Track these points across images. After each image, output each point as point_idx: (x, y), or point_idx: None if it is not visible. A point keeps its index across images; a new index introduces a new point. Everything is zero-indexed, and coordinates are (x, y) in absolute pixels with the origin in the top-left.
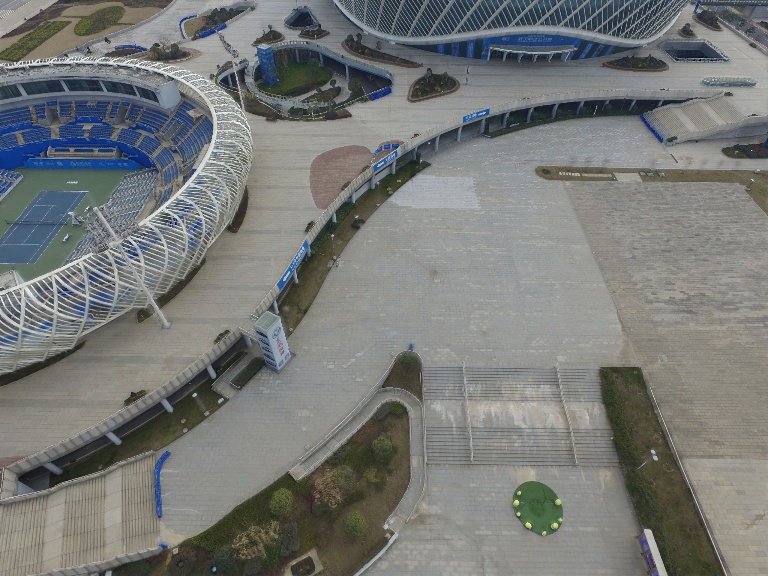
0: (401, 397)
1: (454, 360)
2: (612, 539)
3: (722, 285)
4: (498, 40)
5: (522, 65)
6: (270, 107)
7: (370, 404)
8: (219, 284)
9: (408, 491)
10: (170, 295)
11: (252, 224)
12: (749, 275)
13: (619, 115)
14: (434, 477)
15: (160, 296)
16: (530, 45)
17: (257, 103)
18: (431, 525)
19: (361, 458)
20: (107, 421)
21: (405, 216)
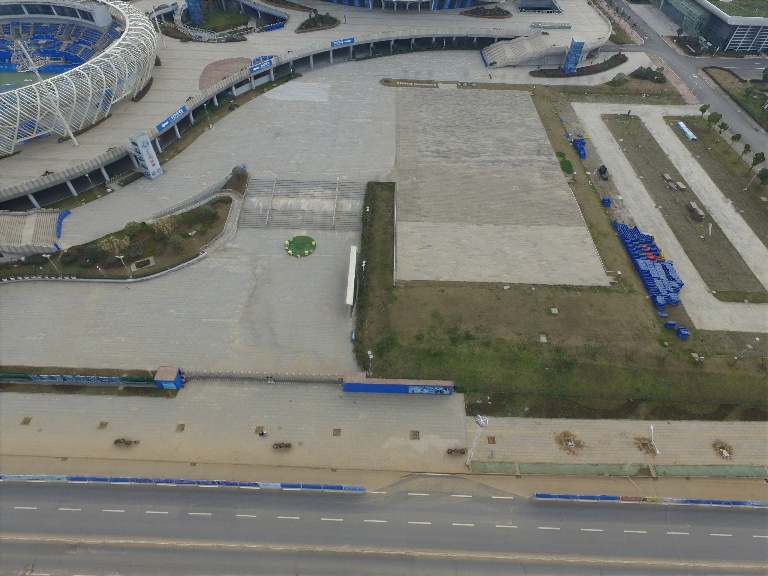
0: (232, 195)
1: (272, 176)
2: (340, 260)
3: (477, 144)
4: None
5: (396, 12)
6: None
7: (209, 197)
8: (118, 127)
9: (221, 237)
10: (82, 131)
11: (150, 98)
12: (500, 140)
13: (464, 49)
14: (241, 233)
15: (75, 131)
16: None
17: (177, 31)
18: (230, 252)
19: (193, 218)
20: (28, 183)
21: (270, 104)
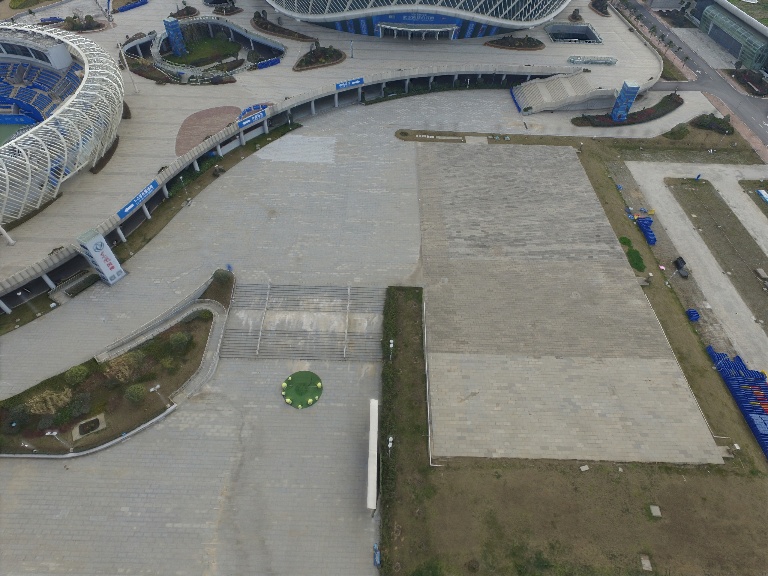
0: (213, 307)
1: (265, 279)
2: (355, 412)
3: (520, 226)
4: (386, 18)
5: (411, 42)
6: (163, 73)
7: (184, 311)
8: (68, 213)
9: (197, 375)
10: (22, 220)
11: (113, 167)
12: (547, 219)
13: (491, 88)
14: (223, 367)
15: (13, 221)
16: (415, 23)
17: (153, 69)
18: (209, 400)
19: (160, 349)
20: None
21: (263, 167)
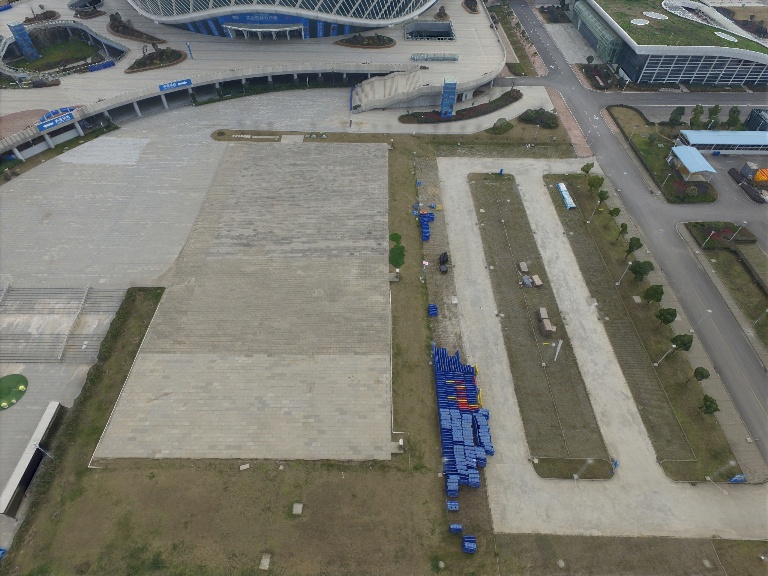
0: None
1: None
2: None
3: (295, 224)
4: (230, 18)
5: (260, 42)
6: None
7: None
8: None
9: None
10: None
11: None
12: (326, 217)
13: (332, 87)
14: None
15: None
16: (261, 23)
17: None
18: None
19: None
20: None
21: (60, 170)
